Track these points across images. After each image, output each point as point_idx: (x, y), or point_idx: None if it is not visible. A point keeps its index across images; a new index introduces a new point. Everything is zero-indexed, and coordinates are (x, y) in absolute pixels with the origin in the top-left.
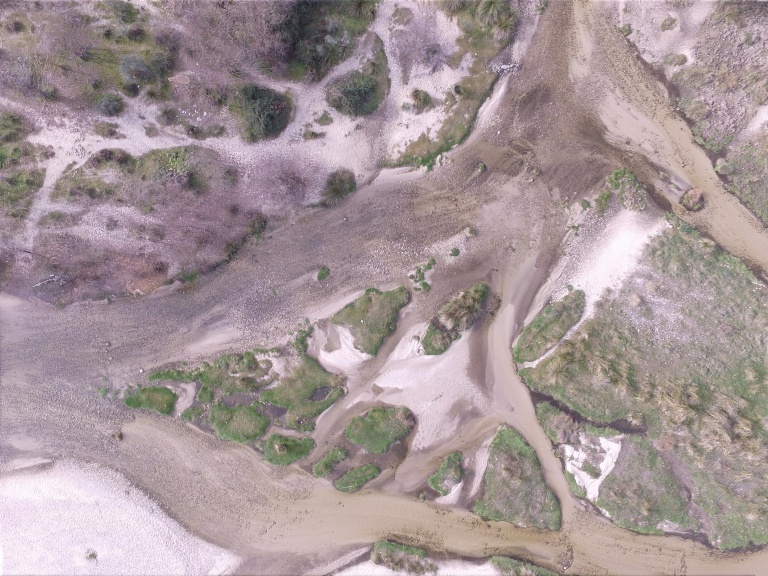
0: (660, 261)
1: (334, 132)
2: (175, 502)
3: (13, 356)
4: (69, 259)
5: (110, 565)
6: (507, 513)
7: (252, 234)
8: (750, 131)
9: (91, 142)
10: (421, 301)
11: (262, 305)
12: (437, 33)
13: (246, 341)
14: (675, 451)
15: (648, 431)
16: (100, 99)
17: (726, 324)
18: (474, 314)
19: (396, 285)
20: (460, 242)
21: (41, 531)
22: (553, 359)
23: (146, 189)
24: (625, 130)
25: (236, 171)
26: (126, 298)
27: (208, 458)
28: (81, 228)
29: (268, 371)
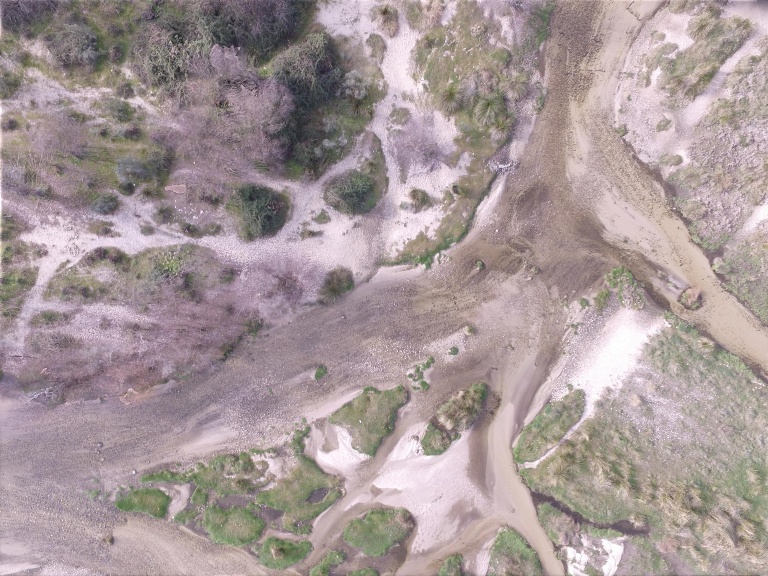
0: (660, 361)
1: (332, 230)
2: None
3: (2, 457)
4: (61, 359)
5: None
6: None
7: (249, 332)
8: (746, 231)
9: (85, 240)
10: (420, 400)
11: (258, 404)
12: (435, 133)
13: (242, 441)
14: (678, 553)
15: (651, 532)
16: (95, 198)
17: (727, 425)
18: (474, 415)
19: (395, 384)
20: (459, 341)
21: None
22: (554, 459)
23: (141, 288)
24: (622, 229)
25: (233, 270)
26: None
27: (202, 562)
28: (74, 327)
29: (264, 472)
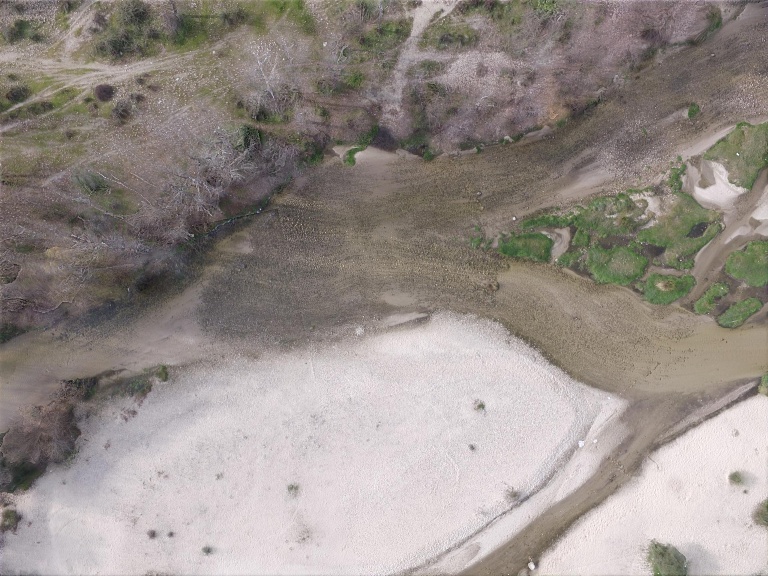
0: None
1: None
2: (556, 349)
3: (382, 211)
4: (440, 108)
5: (498, 415)
6: None
7: (620, 75)
8: None
9: None
10: None
11: (633, 145)
12: None
13: (618, 183)
14: None
15: None
16: None
17: None
18: None
19: (767, 118)
20: None
21: (425, 385)
22: None
23: (517, 32)
24: None
25: (605, 11)
26: (495, 146)
27: (587, 302)
28: (450, 76)
29: (644, 211)
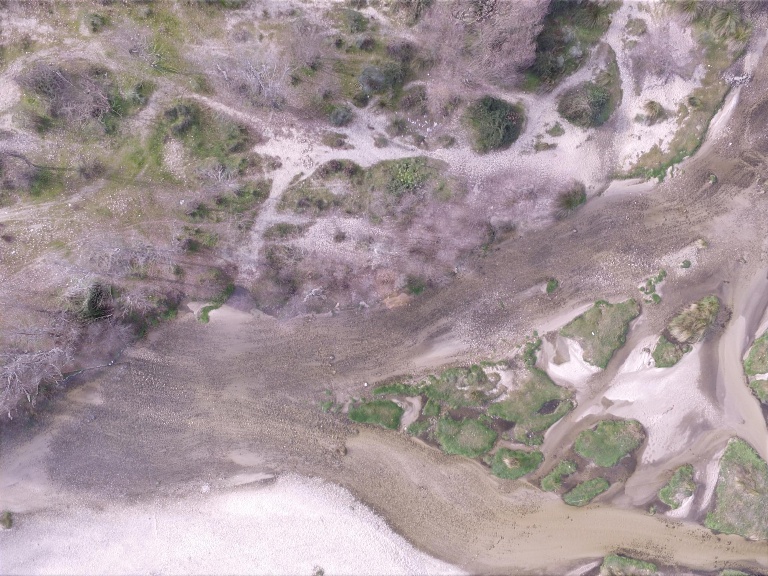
0: None
1: (565, 143)
2: (401, 517)
3: (234, 370)
4: (295, 271)
5: None
6: (739, 526)
7: (480, 246)
8: None
9: (319, 153)
10: (651, 313)
11: (489, 318)
12: (670, 44)
13: (473, 354)
14: None
15: None
16: None
17: None
18: (710, 326)
19: (626, 297)
20: (691, 254)
21: (266, 548)
22: None
23: (376, 200)
24: None
25: (467, 182)
26: (350, 311)
27: (434, 473)
28: (307, 240)
29: (496, 384)
